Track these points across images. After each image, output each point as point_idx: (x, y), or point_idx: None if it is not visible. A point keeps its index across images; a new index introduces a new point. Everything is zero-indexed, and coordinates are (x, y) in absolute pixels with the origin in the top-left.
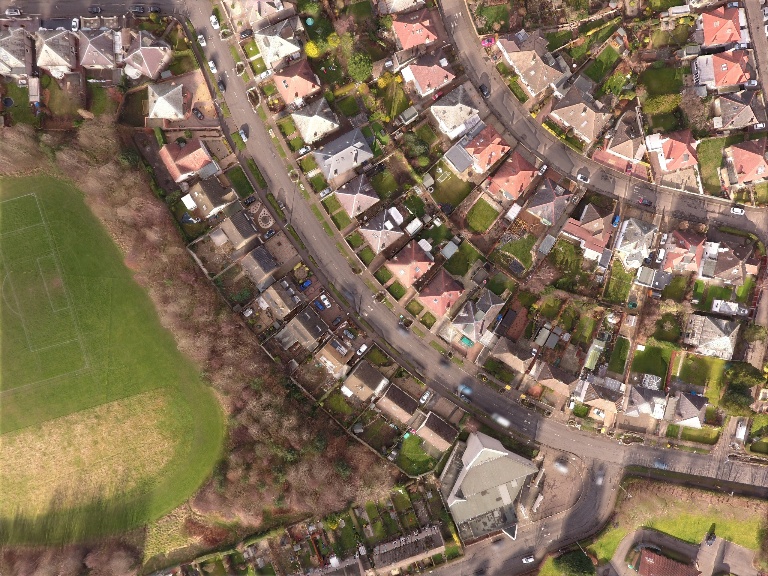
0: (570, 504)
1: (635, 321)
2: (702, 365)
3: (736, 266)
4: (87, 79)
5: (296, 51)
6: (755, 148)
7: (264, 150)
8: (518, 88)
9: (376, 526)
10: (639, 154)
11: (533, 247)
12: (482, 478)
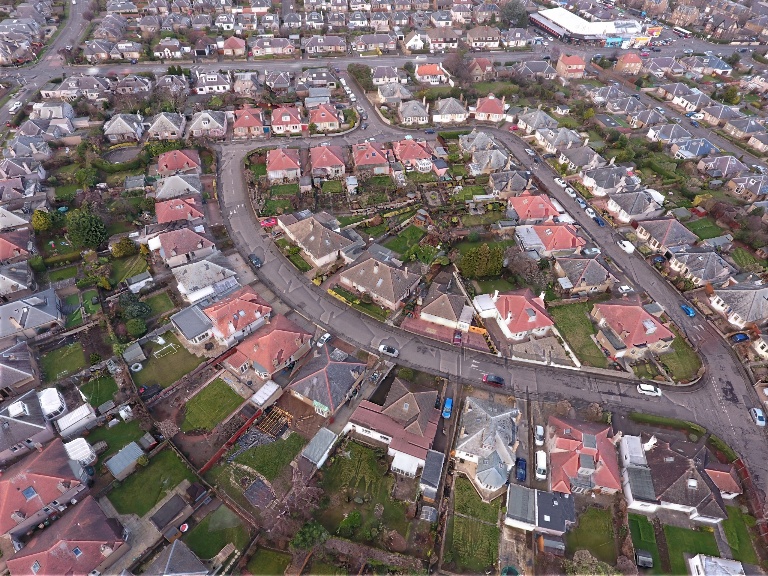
0: None
1: None
2: None
3: (687, 471)
4: None
5: (23, 225)
6: (627, 302)
7: None
8: (300, 259)
9: None
10: (465, 316)
11: (298, 455)
12: None
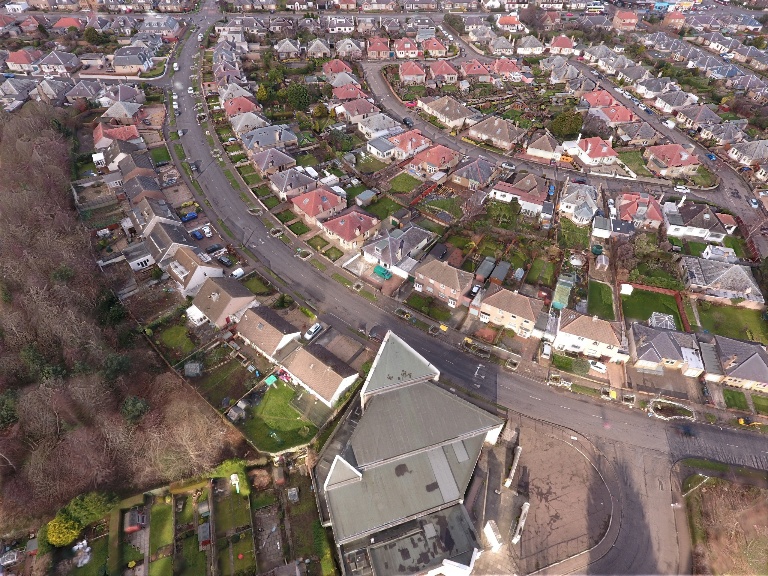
0: (593, 535)
1: (606, 260)
2: (728, 315)
3: (704, 210)
4: (64, 103)
5: None
6: None
7: (195, 141)
8: (438, 123)
9: (158, 568)
10: (558, 150)
11: (463, 205)
12: (394, 426)
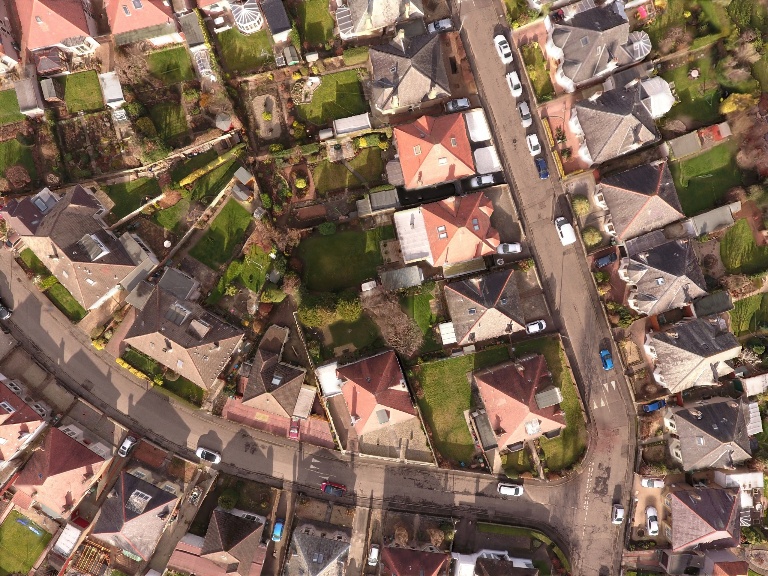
0: None
1: None
2: None
3: None
4: None
5: None
6: (518, 385)
7: None
8: (65, 294)
9: None
10: (302, 407)
11: None
12: None
